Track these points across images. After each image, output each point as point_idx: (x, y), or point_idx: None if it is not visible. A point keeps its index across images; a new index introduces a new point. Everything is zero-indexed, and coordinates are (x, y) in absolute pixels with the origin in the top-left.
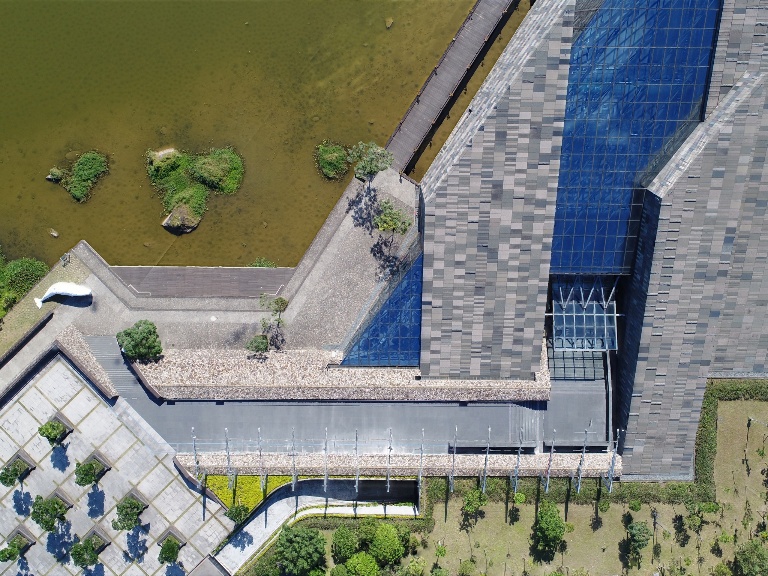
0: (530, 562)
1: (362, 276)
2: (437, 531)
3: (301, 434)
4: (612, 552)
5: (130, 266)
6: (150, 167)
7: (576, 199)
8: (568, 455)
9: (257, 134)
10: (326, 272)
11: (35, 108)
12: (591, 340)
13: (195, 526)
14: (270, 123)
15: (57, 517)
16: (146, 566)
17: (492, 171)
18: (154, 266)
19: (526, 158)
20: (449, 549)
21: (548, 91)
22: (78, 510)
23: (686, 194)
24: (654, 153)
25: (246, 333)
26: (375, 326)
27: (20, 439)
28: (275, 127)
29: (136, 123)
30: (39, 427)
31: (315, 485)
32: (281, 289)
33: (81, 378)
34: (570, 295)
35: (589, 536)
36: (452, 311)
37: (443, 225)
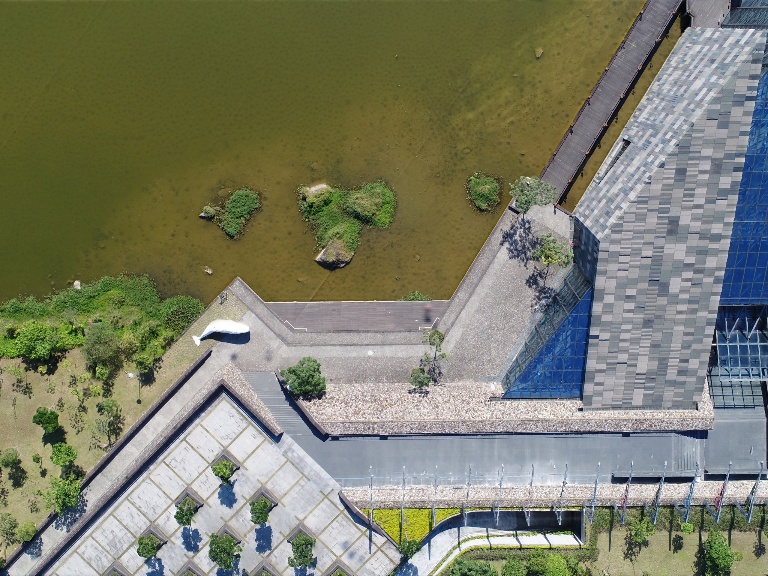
0: None
1: (518, 308)
2: (601, 560)
3: (465, 467)
4: None
5: (285, 302)
6: (303, 203)
7: (750, 232)
8: (731, 483)
9: (408, 167)
10: (482, 304)
11: (186, 146)
12: None
13: (361, 559)
14: (421, 156)
15: (233, 555)
16: None
17: (669, 207)
18: (309, 302)
19: (704, 194)
20: None
21: (732, 128)
22: (246, 546)
23: None
24: None
25: (403, 367)
26: None
27: (187, 477)
28: (426, 160)
29: (287, 159)
30: (213, 467)
31: (476, 516)
32: (436, 322)
33: (246, 416)
34: (735, 325)
35: (752, 563)
36: (619, 344)
37: (616, 261)
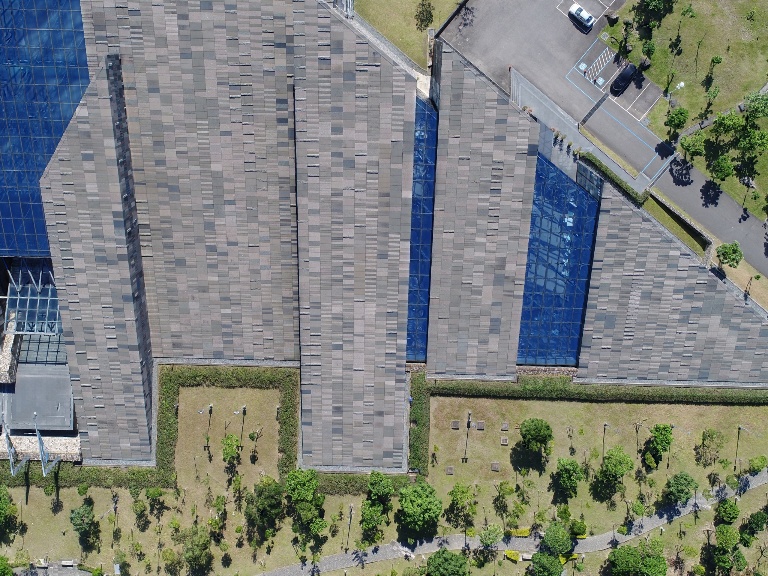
0: None
1: None
2: None
3: None
4: (72, 536)
5: None
6: None
7: None
8: (29, 438)
9: None
10: None
11: None
12: None
13: None
14: None
15: None
16: None
17: None
18: None
19: None
20: None
21: None
22: None
23: (62, 177)
24: (58, 136)
25: None
26: None
27: None
28: None
29: None
30: None
31: None
32: None
33: None
34: (20, 278)
35: (50, 519)
36: None
37: None
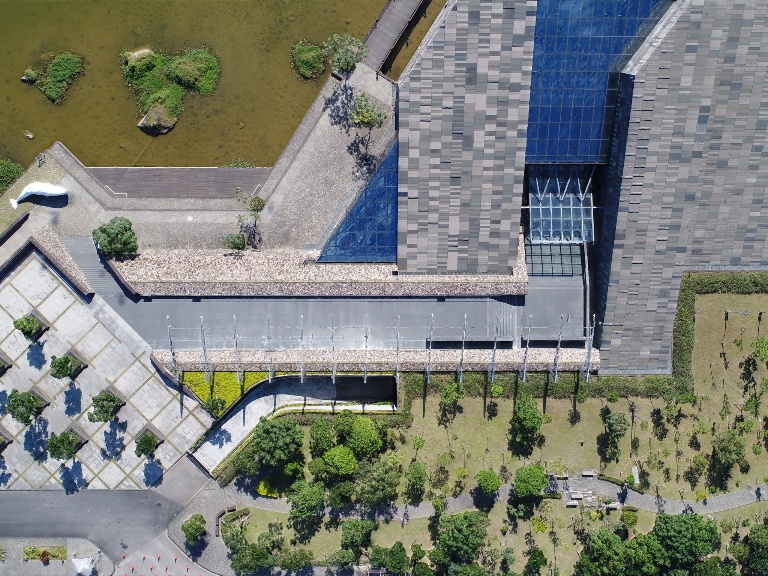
0: (508, 454)
1: (339, 175)
2: (415, 427)
3: (278, 330)
4: (590, 446)
5: (106, 167)
6: (125, 67)
7: (551, 84)
8: (546, 349)
9: (233, 34)
10: (303, 171)
11: (9, 9)
12: (569, 237)
13: (173, 423)
14: (246, 23)
15: None
16: (124, 464)
17: (466, 53)
18: (130, 167)
19: (500, 39)
20: (427, 444)
21: None
22: (55, 408)
23: (659, 70)
24: (628, 35)
25: (223, 233)
26: (352, 225)
27: None
28: (251, 27)
29: (111, 24)
30: (14, 320)
31: (293, 384)
32: (258, 189)
33: (57, 275)
34: (546, 187)
35: (567, 430)
36: (428, 202)
37: (418, 111)
